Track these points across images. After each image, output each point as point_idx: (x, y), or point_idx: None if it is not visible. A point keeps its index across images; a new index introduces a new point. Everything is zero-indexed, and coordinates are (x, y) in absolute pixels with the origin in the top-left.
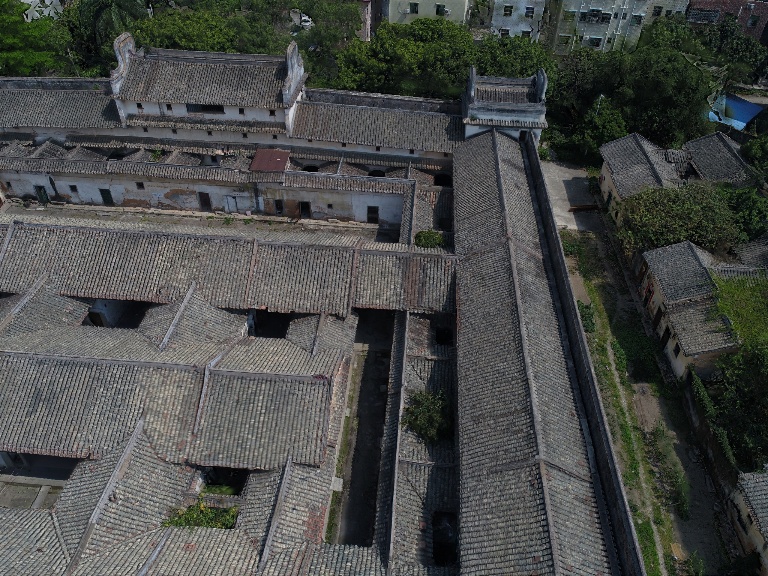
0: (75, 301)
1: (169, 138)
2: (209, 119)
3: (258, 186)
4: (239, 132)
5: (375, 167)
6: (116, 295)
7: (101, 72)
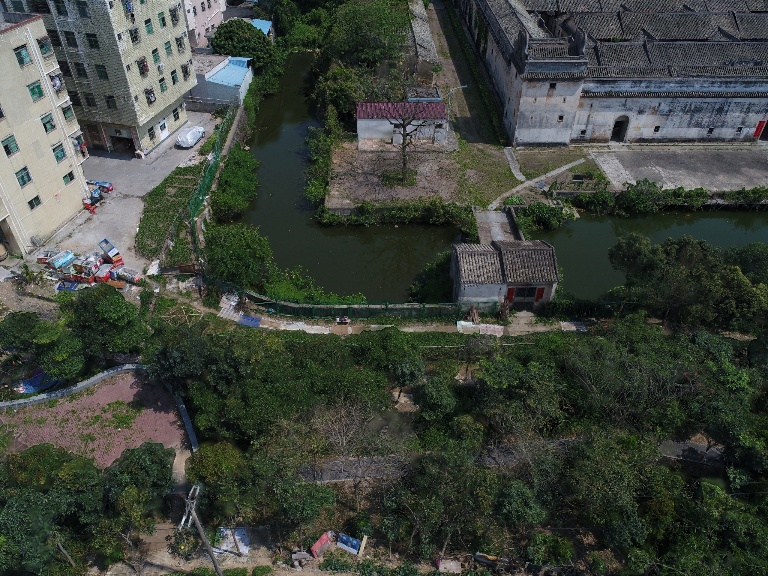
0: None
1: None
2: None
3: None
4: None
5: None
6: None
7: None
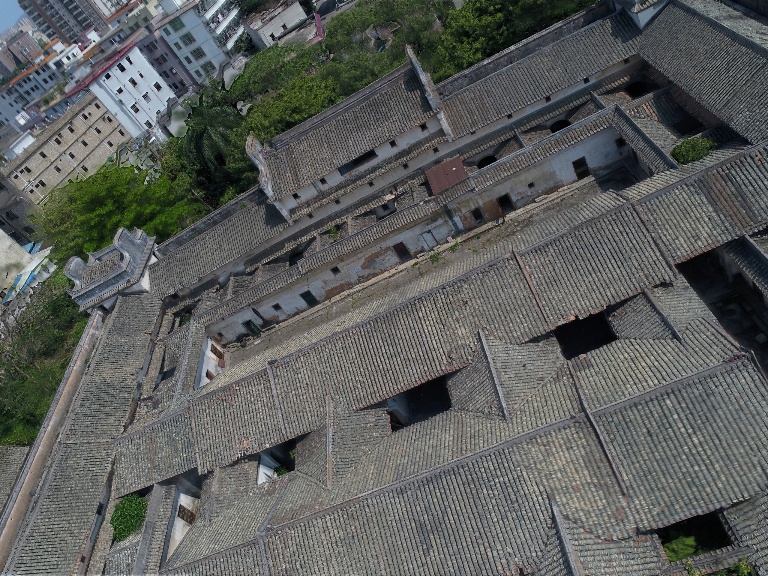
0: (370, 411)
1: (335, 211)
2: (365, 170)
3: (449, 207)
4: (399, 166)
5: (552, 120)
6: (409, 384)
7: (236, 190)
